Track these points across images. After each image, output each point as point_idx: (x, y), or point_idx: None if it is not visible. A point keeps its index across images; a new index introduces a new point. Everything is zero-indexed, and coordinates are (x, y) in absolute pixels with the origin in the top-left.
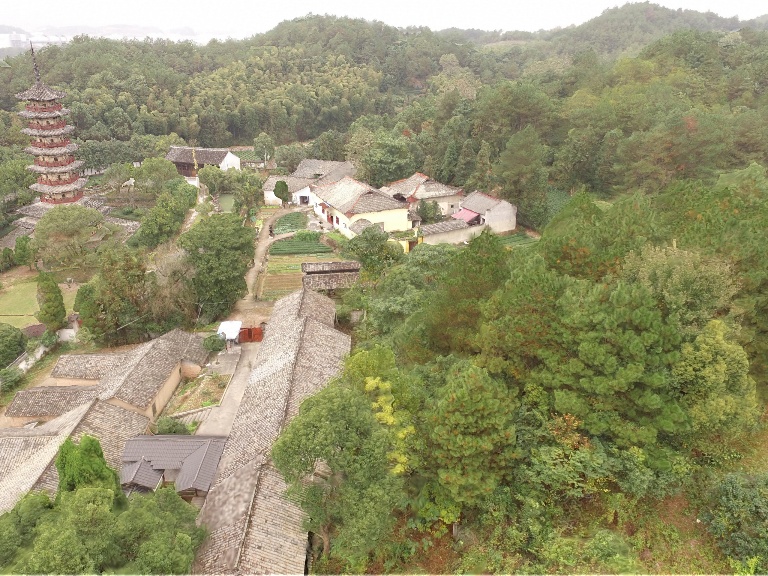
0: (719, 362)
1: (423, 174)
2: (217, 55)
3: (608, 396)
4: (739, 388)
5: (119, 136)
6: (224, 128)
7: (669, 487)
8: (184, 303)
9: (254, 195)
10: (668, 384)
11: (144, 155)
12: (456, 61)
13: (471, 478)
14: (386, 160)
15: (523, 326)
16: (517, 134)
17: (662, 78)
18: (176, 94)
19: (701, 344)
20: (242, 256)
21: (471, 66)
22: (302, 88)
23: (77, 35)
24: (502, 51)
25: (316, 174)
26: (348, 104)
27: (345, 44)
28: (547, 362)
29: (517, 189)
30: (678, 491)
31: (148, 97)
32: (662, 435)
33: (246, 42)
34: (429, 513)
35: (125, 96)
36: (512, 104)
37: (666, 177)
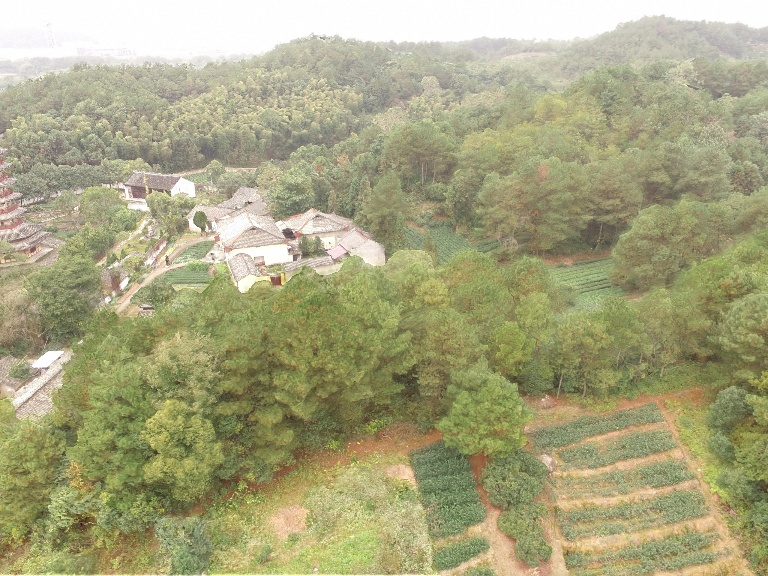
0: (163, 433)
1: (315, 210)
2: (209, 78)
3: (104, 452)
4: (198, 452)
5: (93, 160)
6: (196, 151)
7: (134, 524)
8: (27, 333)
9: (176, 223)
10: (136, 446)
11: (112, 178)
12: (436, 83)
13: (9, 507)
14: (283, 196)
15: (72, 393)
16: (383, 179)
17: (567, 118)
18: (153, 120)
19: (151, 418)
20: (86, 293)
21: (454, 87)
22: (273, 113)
23: (77, 63)
24: (494, 70)
25: (248, 202)
26: (318, 128)
27: (331, 67)
28: (84, 422)
29: (383, 229)
30: (139, 528)
31: (125, 123)
32: (126, 485)
33: (243, 64)
34: (6, 530)
35: (102, 123)
36: (411, 144)
37: (518, 222)
